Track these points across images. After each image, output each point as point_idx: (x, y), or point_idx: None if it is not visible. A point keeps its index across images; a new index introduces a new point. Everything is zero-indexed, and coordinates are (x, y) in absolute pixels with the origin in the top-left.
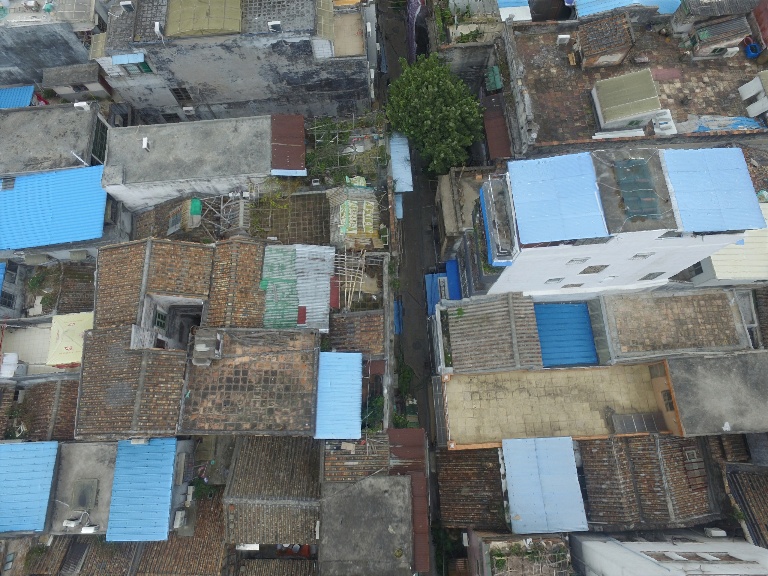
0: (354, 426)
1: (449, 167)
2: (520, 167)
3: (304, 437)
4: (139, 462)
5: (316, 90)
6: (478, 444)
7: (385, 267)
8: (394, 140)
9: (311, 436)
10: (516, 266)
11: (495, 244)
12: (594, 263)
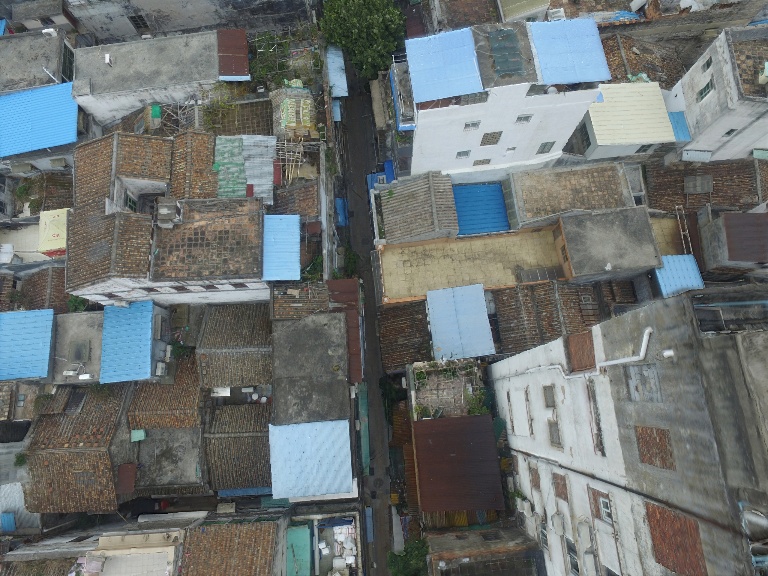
0: (294, 270)
1: None
2: (415, 44)
3: (263, 304)
4: (123, 322)
5: (260, 14)
6: (407, 297)
7: (321, 153)
8: (330, 53)
9: None
10: (422, 133)
11: (400, 112)
12: (487, 129)
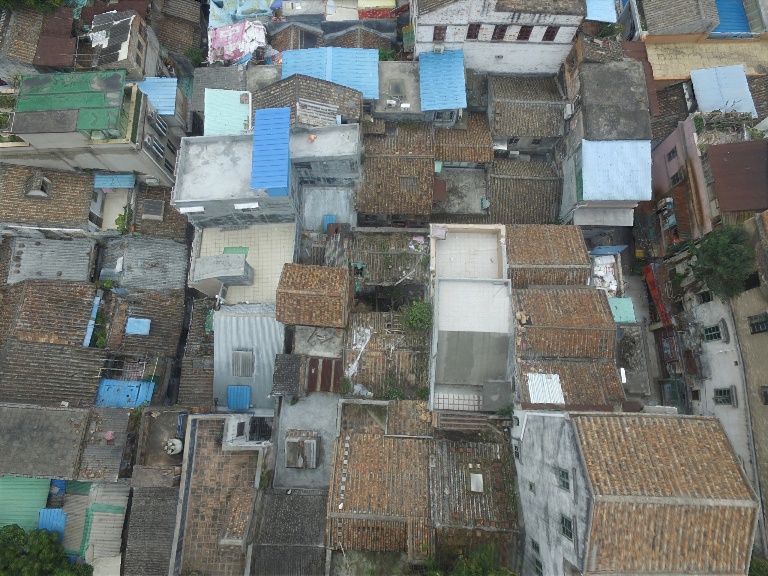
0: (612, 14)
1: None
2: None
3: (537, 78)
4: (437, 65)
5: None
6: (670, 76)
7: None
8: None
9: (542, 77)
10: None
11: None
12: None
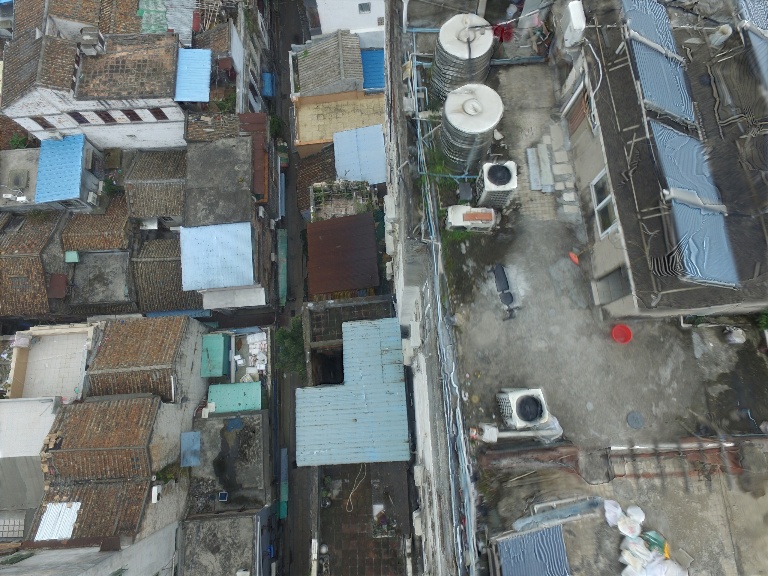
0: (204, 93)
1: None
2: None
3: None
4: (57, 152)
5: None
6: (317, 140)
7: (239, 9)
8: None
9: None
10: None
11: None
12: None
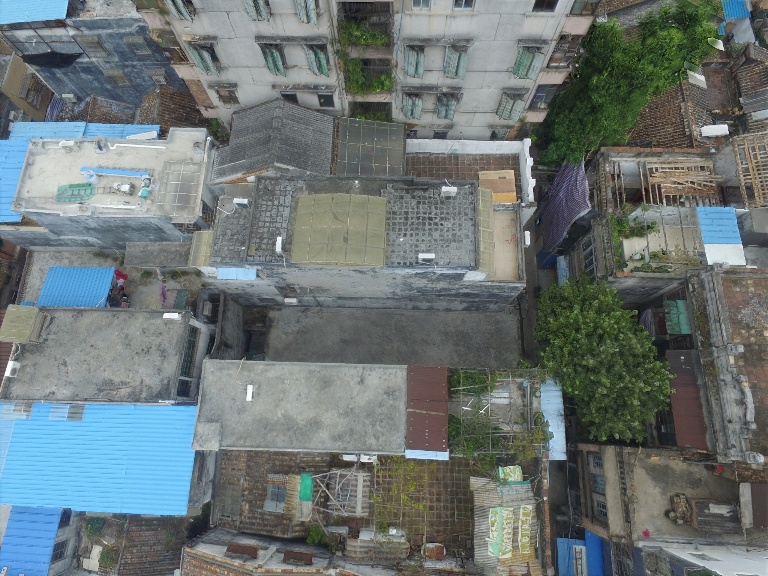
0: None
1: None
2: None
3: None
4: None
5: (448, 296)
6: None
7: None
8: (545, 384)
9: None
10: None
11: None
12: None
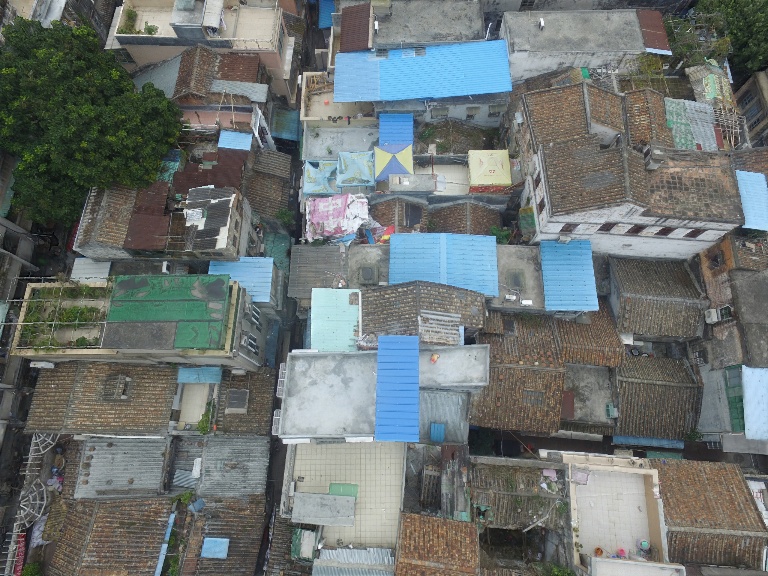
0: None
1: (763, 66)
2: None
3: (664, 262)
4: (562, 256)
5: (635, 5)
6: None
7: (745, 126)
8: None
9: (669, 262)
10: None
11: None
12: None
